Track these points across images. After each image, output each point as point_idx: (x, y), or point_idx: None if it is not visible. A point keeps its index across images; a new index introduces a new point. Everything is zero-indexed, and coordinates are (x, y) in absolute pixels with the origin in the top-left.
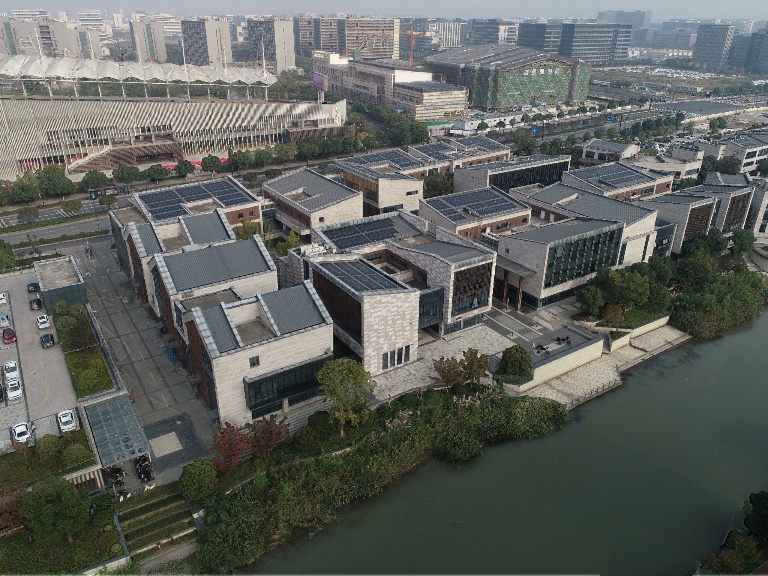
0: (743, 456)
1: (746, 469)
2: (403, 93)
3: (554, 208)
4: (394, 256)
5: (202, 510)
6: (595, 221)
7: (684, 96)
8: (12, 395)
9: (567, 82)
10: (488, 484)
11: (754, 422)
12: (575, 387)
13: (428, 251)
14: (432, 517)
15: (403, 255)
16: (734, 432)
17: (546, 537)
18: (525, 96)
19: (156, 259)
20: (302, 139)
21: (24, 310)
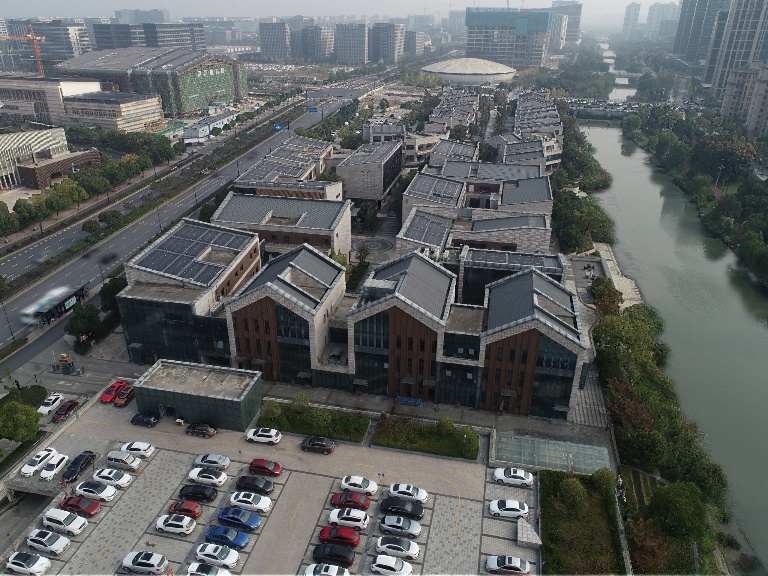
0: (730, 292)
1: (739, 297)
2: (82, 108)
3: (473, 179)
4: (465, 242)
5: (658, 471)
6: (524, 181)
7: (309, 85)
8: (424, 496)
9: (232, 81)
10: (693, 364)
11: (701, 275)
12: (626, 294)
13: (500, 228)
14: (712, 395)
15: (480, 238)
16: (708, 283)
17: (753, 372)
18: (203, 98)
19: (401, 299)
20: (76, 173)
21: (198, 443)
